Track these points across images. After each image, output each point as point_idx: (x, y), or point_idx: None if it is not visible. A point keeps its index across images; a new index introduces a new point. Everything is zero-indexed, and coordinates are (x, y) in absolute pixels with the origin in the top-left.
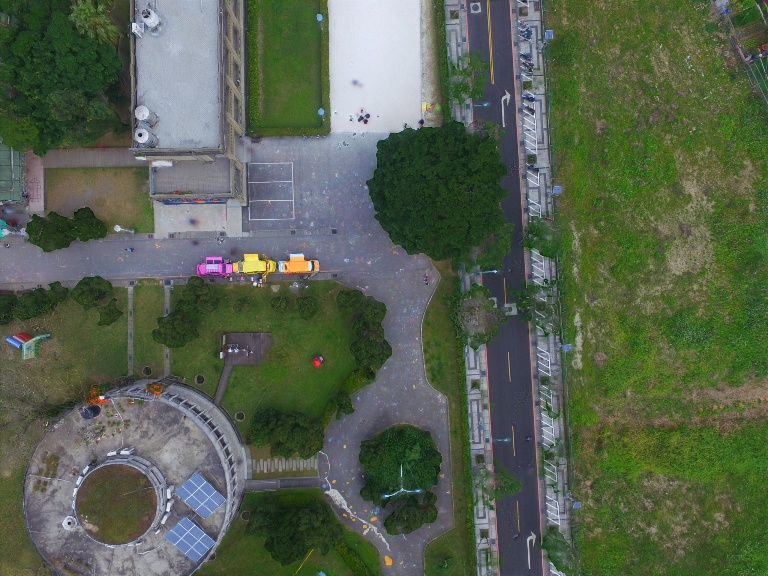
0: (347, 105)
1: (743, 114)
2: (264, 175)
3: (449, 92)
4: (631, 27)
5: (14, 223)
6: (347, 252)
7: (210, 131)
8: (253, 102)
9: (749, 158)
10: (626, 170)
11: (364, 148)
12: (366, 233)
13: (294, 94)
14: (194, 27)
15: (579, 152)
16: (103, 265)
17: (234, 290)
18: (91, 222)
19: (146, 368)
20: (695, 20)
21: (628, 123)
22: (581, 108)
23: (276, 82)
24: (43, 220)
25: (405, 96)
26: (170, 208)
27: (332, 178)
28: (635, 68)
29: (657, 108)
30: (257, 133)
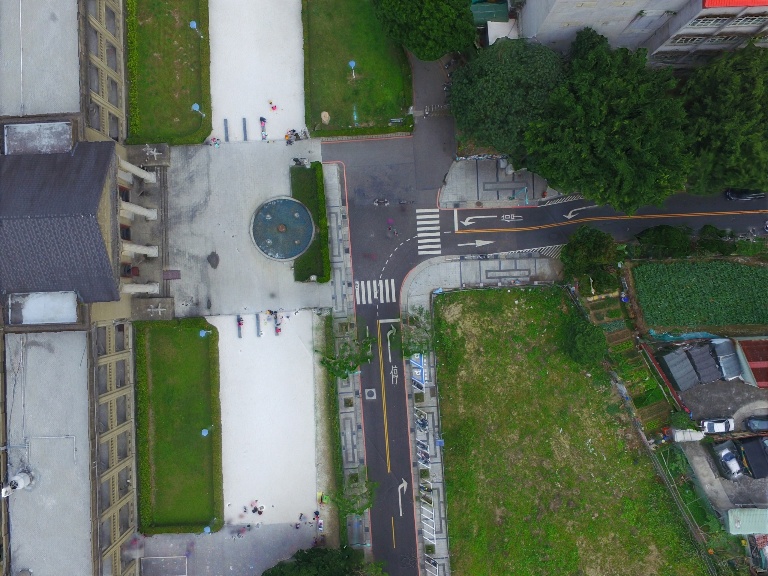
0: (241, 496)
1: (647, 500)
2: (158, 569)
3: (343, 486)
4: (530, 412)
5: None
6: None
7: None
8: (144, 501)
9: (654, 543)
10: (527, 561)
11: (259, 540)
12: None
13: (187, 486)
14: (68, 480)
15: (478, 544)
16: None
17: None
18: None
19: None
20: (596, 403)
21: (528, 510)
22: (480, 496)
23: (168, 474)
24: None
25: (300, 485)
26: None
27: (227, 571)
28: (535, 453)
29: (558, 494)
30: (148, 533)
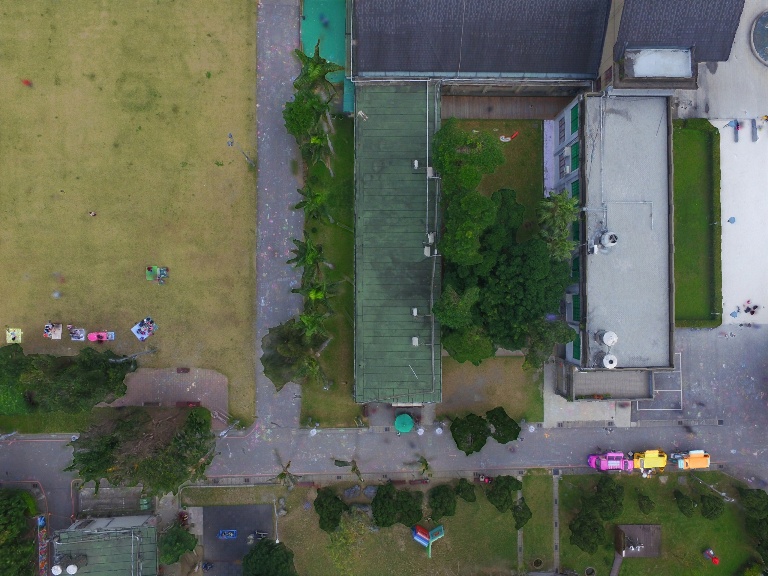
0: (734, 296)
1: None
2: None
3: None
4: None
5: (408, 413)
6: (734, 443)
7: (658, 348)
8: None
9: None
10: None
11: (751, 339)
12: (752, 424)
13: (682, 284)
14: (643, 245)
15: None
16: (493, 454)
17: (623, 481)
18: (512, 425)
19: (537, 560)
20: None
21: None
22: None
23: None
24: (467, 424)
25: None
26: (560, 398)
27: (720, 369)
28: None
29: None
30: None
